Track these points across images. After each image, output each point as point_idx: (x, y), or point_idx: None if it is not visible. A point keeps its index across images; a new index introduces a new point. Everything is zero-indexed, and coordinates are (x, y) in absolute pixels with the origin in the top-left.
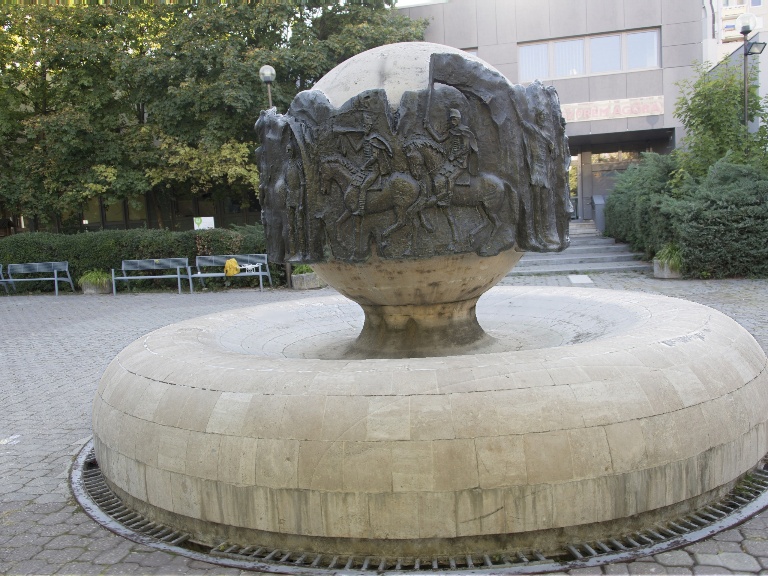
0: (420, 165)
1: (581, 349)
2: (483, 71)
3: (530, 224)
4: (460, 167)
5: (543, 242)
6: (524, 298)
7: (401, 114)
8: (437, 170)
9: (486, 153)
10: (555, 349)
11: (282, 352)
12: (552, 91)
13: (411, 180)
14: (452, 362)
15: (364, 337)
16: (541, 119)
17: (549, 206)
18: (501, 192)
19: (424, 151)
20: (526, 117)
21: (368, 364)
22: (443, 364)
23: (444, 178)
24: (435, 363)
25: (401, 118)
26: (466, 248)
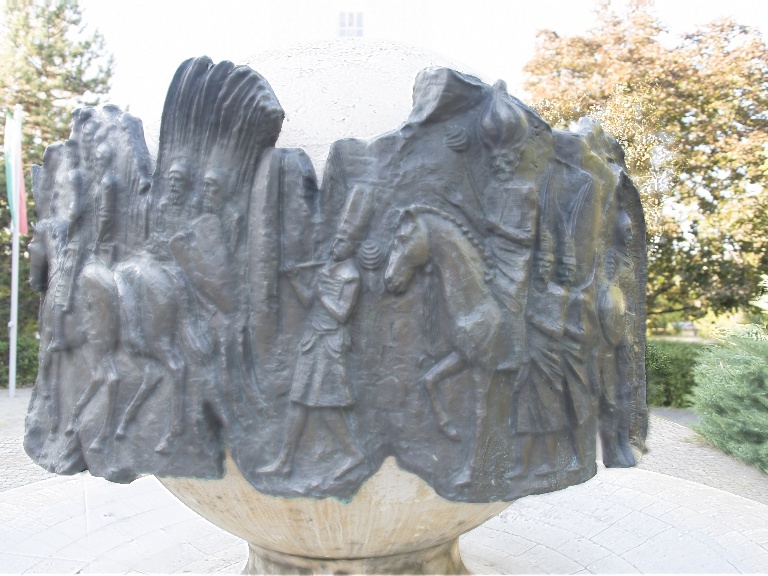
0: None
1: (636, 470)
2: None
3: None
4: None
5: None
6: (109, 501)
7: None
8: None
9: None
10: (643, 475)
11: None
12: None
13: None
14: None
15: None
16: None
17: None
18: None
19: None
20: None
21: None
22: (755, 505)
23: None
24: (756, 508)
25: None
26: None
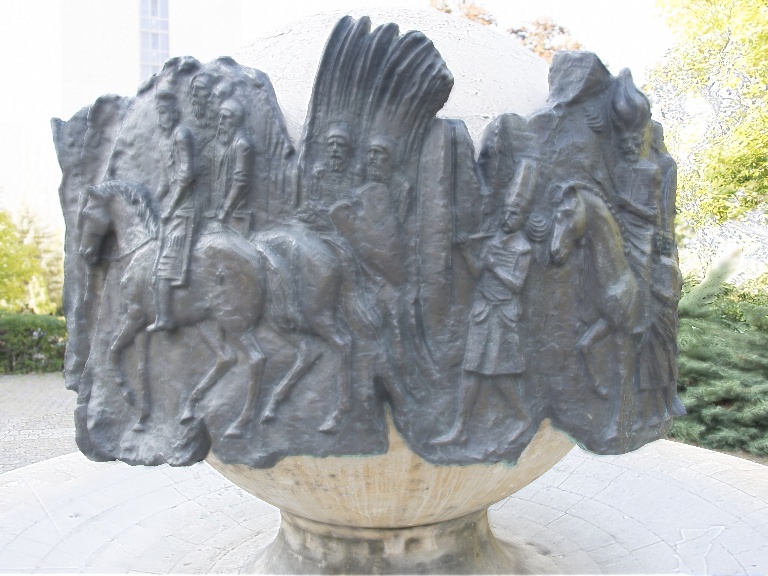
0: None
1: None
2: None
3: None
4: None
5: None
6: (67, 501)
7: None
8: None
9: None
10: None
11: None
12: None
13: None
14: (672, 444)
15: (488, 571)
16: None
17: None
18: None
19: None
20: None
21: (734, 463)
22: (682, 445)
23: None
24: (685, 447)
25: None
26: None
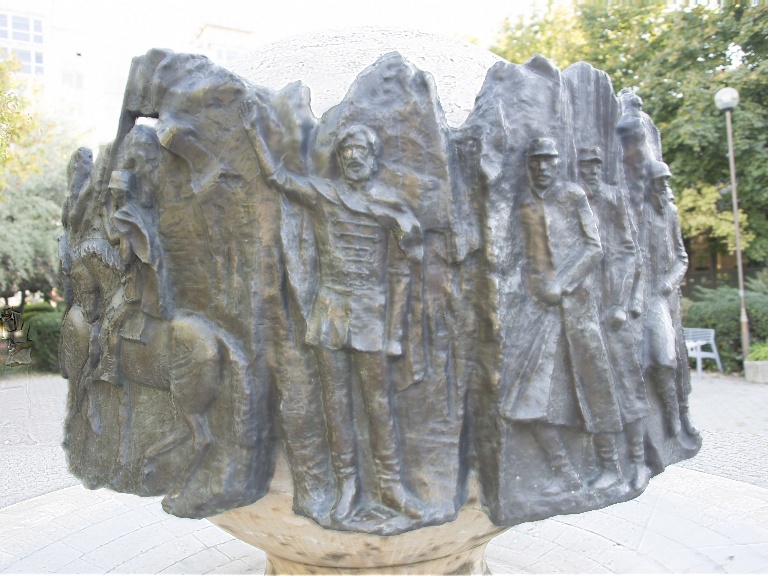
0: (90, 292)
1: None
2: (187, 70)
3: (309, 448)
4: (125, 299)
5: (335, 506)
6: (767, 556)
7: (80, 191)
8: (107, 303)
9: (186, 264)
10: None
11: (209, 546)
12: (496, 70)
13: (80, 322)
14: None
15: None
16: (346, 161)
17: (414, 398)
18: (203, 361)
19: (90, 264)
20: (296, 163)
21: None
22: None
23: (107, 322)
24: None
25: (79, 199)
26: (135, 485)
